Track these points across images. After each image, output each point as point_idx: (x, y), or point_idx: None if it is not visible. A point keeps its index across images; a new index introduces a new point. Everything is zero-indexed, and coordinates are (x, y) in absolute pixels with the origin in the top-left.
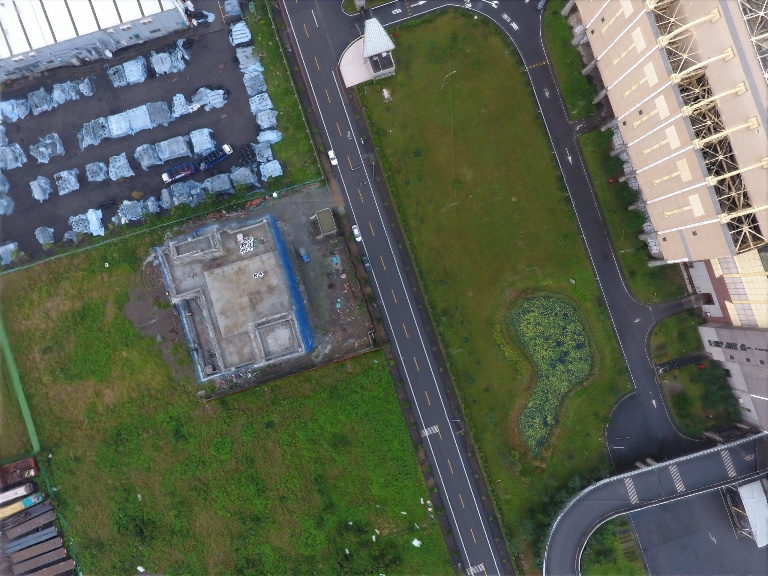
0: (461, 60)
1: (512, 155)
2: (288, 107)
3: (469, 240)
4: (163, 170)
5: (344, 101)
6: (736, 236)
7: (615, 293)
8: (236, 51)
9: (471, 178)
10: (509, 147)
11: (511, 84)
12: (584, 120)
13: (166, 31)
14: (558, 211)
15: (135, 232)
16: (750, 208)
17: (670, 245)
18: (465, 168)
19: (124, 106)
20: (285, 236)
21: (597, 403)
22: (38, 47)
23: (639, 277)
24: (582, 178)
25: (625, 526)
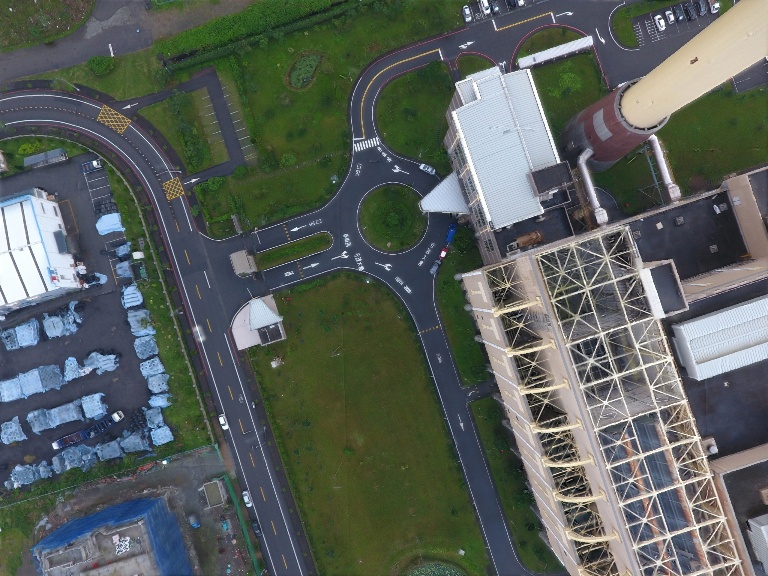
0: (353, 324)
1: (403, 421)
2: (179, 372)
3: (360, 507)
4: (55, 434)
5: (236, 364)
6: (601, 571)
7: (506, 562)
8: (127, 315)
9: (362, 444)
10: (400, 413)
11: (403, 349)
12: (476, 386)
13: (58, 294)
14: (449, 479)
15: (26, 499)
16: (611, 553)
17: (551, 538)
18: (356, 434)
19: (17, 369)
20: (176, 501)
21: None
22: None
23: (530, 547)
24: (474, 445)
25: None
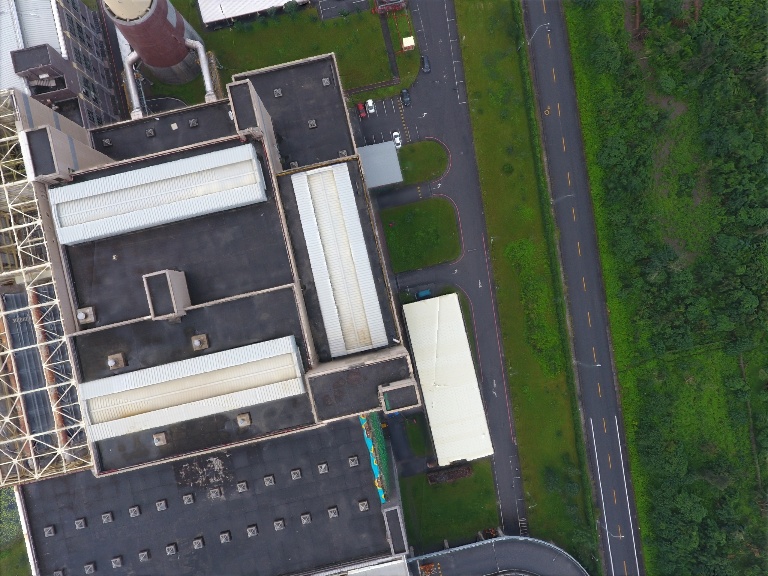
0: None
1: None
2: None
3: None
4: None
5: None
6: None
7: None
8: None
9: None
10: None
11: None
12: None
13: None
14: None
15: None
16: None
17: None
18: None
19: None
20: None
21: (6, 569)
22: None
23: None
24: None
25: None
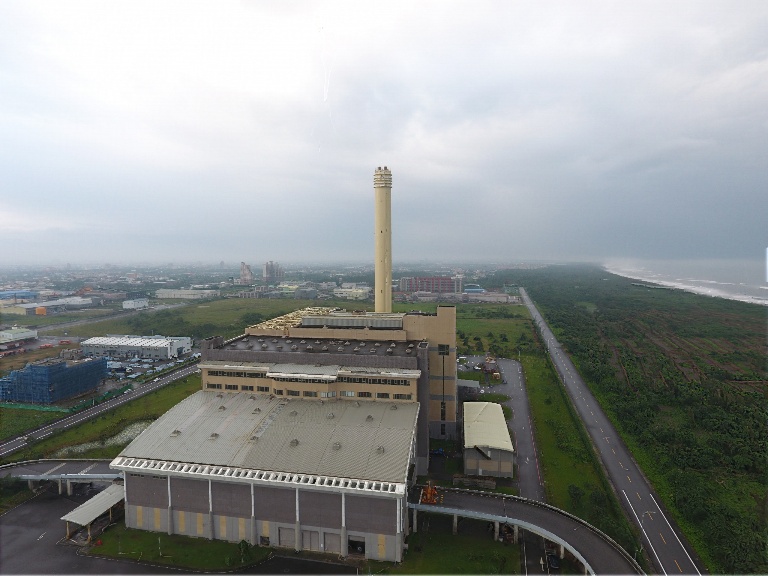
0: None
1: None
2: None
3: None
4: None
5: None
6: None
7: None
8: None
9: None
10: None
11: None
12: None
13: (160, 358)
14: None
15: None
16: None
17: None
18: None
19: None
20: None
21: None
22: (120, 345)
23: None
24: None
25: (11, 502)
